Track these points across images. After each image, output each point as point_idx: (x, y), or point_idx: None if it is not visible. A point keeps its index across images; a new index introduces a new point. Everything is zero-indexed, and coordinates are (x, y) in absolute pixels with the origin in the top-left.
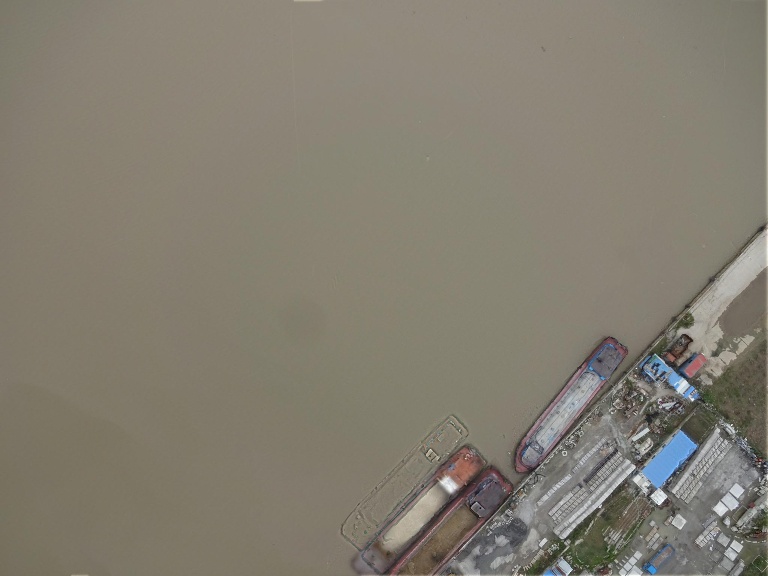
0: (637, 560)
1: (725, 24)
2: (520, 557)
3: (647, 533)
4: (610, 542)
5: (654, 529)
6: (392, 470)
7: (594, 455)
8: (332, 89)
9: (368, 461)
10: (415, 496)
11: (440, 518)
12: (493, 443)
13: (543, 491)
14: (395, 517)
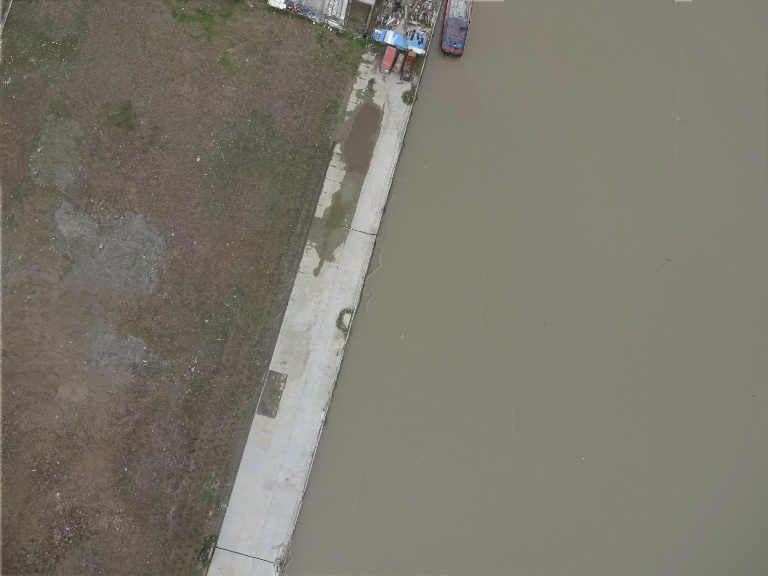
0: None
1: None
2: None
3: None
4: None
5: None
6: None
7: None
8: None
9: None
10: None
11: None
12: None
13: None
14: None
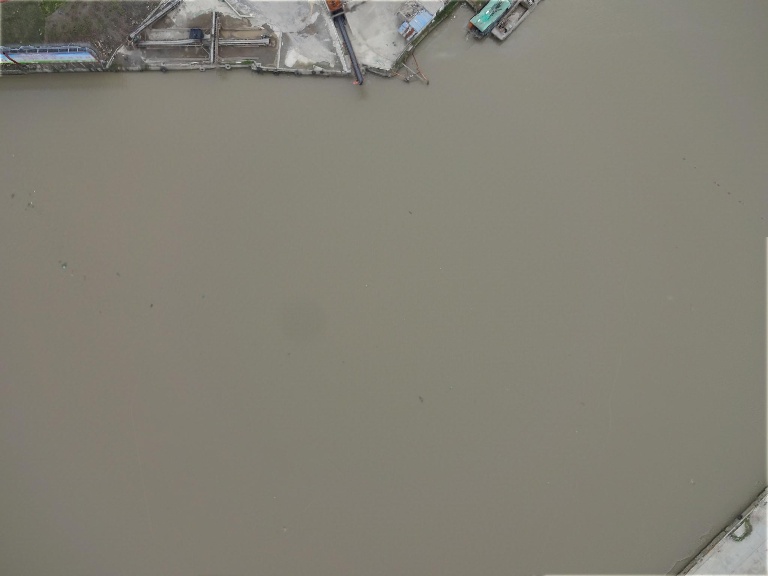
0: None
1: (613, 379)
2: None
3: None
4: None
5: None
6: None
7: None
8: (180, 471)
9: None
10: None
11: None
12: None
13: None
14: None
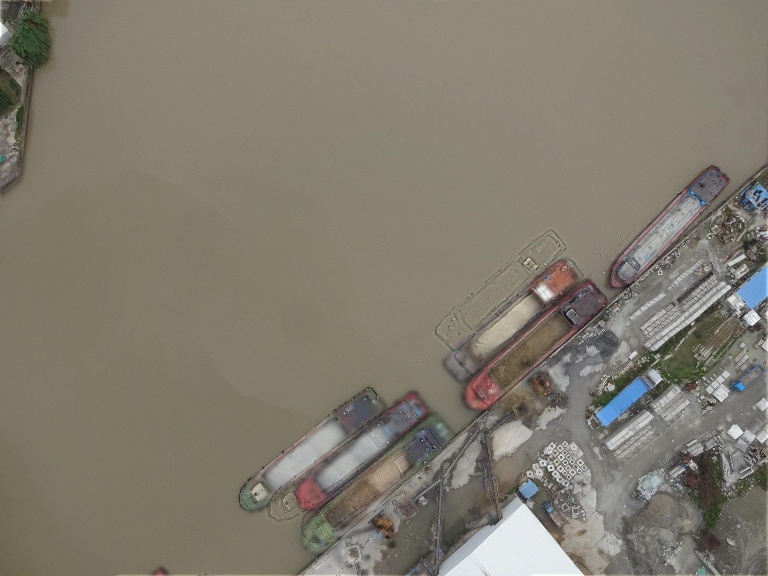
0: (725, 379)
1: None
2: (609, 367)
3: (736, 354)
4: (700, 358)
5: (744, 351)
6: (489, 278)
7: (689, 276)
8: None
9: (466, 268)
10: (510, 304)
11: (533, 325)
12: (589, 261)
13: (636, 307)
14: (489, 322)
